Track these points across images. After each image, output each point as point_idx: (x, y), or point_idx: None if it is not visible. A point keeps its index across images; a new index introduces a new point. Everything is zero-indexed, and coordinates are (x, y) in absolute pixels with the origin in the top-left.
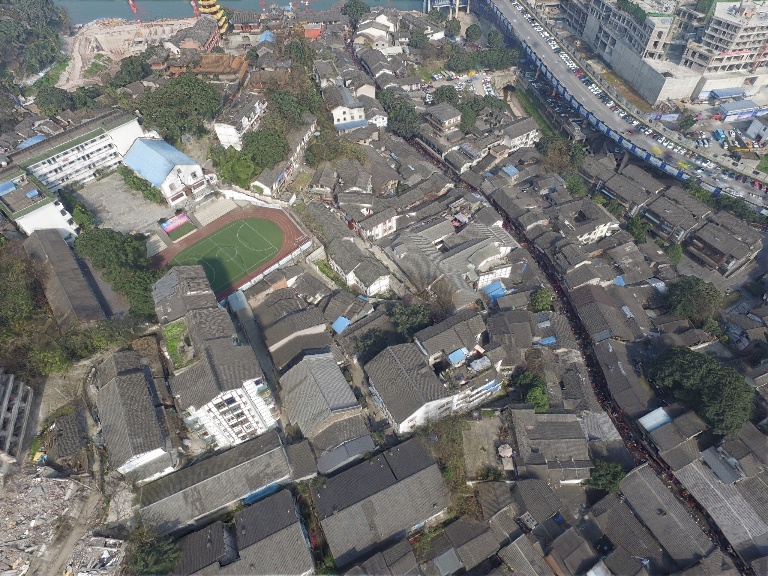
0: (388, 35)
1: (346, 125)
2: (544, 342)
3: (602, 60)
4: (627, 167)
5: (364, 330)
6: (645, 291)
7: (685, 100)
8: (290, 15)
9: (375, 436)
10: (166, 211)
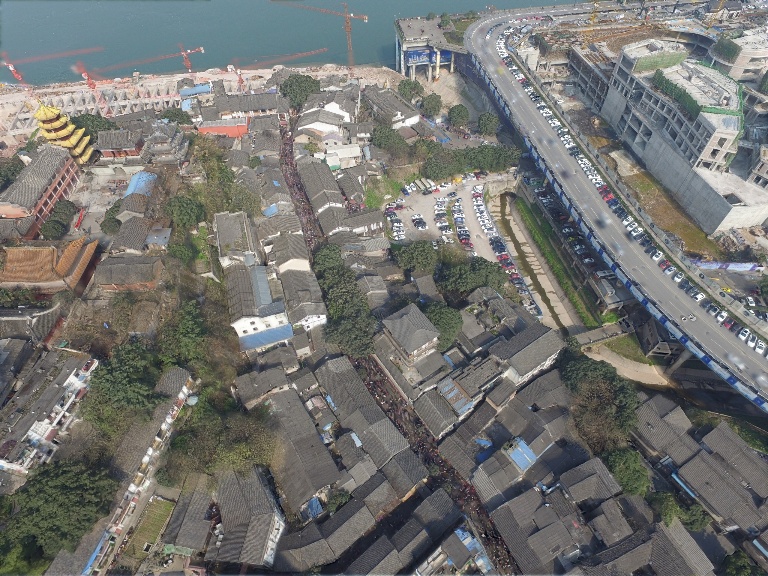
0: (342, 129)
1: (258, 338)
2: None
3: (630, 152)
4: (712, 433)
5: None
6: None
7: (756, 231)
8: (211, 97)
9: None
10: None
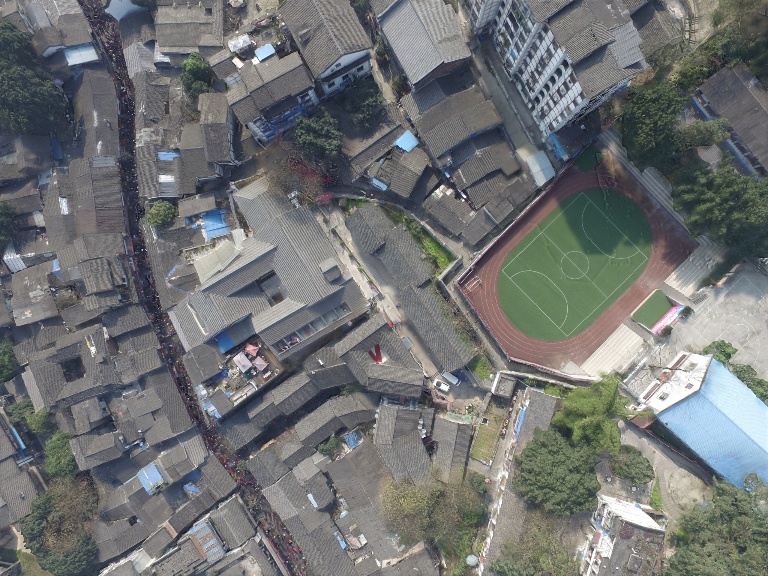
0: None
1: None
2: (173, 155)
3: None
4: None
5: (379, 136)
6: (32, 248)
7: None
8: None
9: (364, 1)
10: (688, 339)
